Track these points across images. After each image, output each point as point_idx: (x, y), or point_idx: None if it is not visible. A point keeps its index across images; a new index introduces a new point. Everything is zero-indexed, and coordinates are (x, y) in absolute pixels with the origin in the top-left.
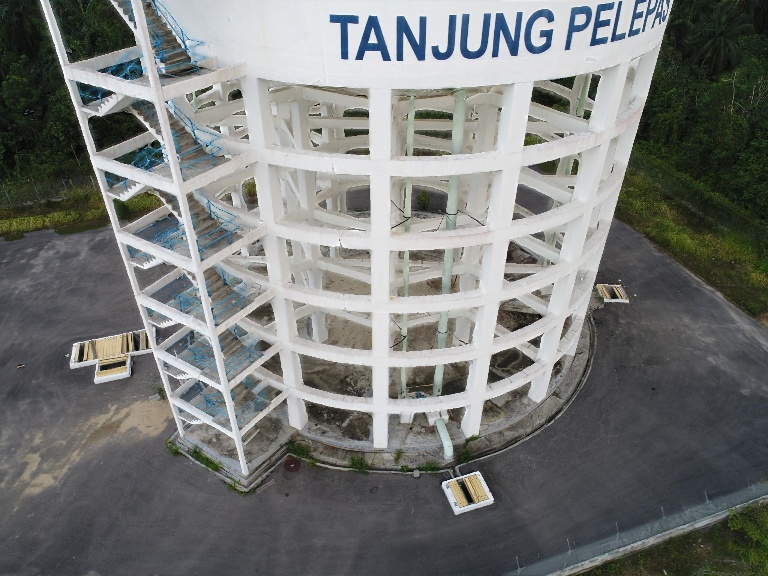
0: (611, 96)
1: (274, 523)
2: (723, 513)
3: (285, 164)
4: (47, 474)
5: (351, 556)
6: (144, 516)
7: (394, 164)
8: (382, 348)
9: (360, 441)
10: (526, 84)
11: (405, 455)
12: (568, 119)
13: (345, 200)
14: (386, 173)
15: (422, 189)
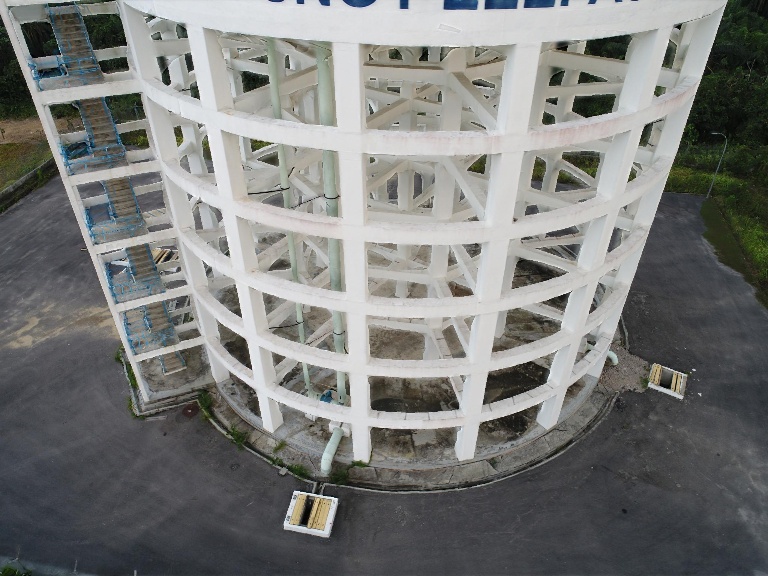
0: (509, 89)
1: (136, 453)
2: None
3: (153, 98)
4: (32, 337)
5: (167, 514)
6: (59, 399)
7: (221, 116)
8: (250, 323)
9: (255, 416)
10: (349, 46)
11: (288, 449)
12: (488, 115)
13: None
14: (217, 125)
15: None
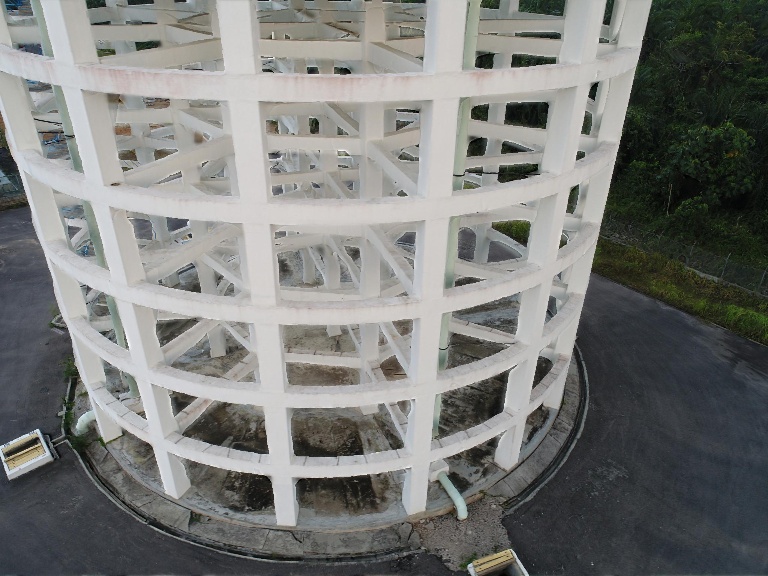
0: None
1: (18, 346)
2: None
3: None
4: None
5: None
6: (39, 291)
7: None
8: None
9: None
10: None
11: (87, 399)
12: None
13: (483, 252)
14: None
15: (621, 315)
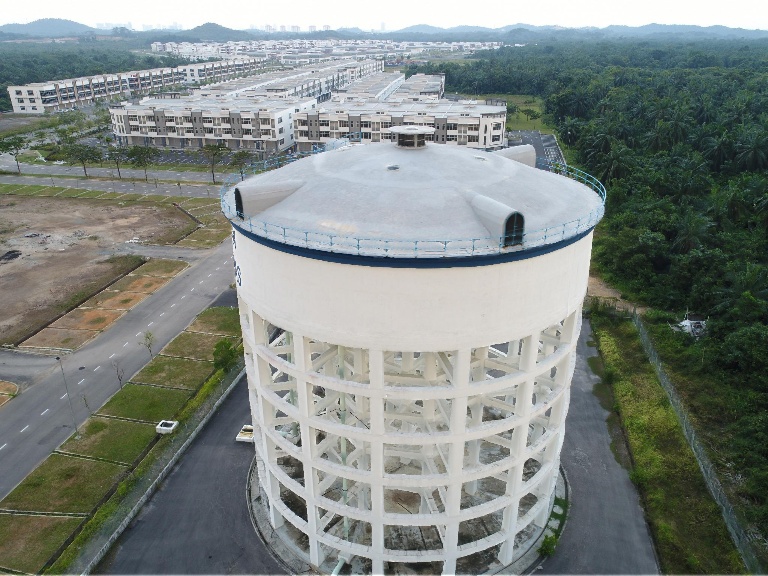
0: None
1: None
2: (133, 509)
3: None
4: None
5: None
6: None
7: None
8: None
9: None
10: None
11: None
12: None
13: None
14: None
15: None
